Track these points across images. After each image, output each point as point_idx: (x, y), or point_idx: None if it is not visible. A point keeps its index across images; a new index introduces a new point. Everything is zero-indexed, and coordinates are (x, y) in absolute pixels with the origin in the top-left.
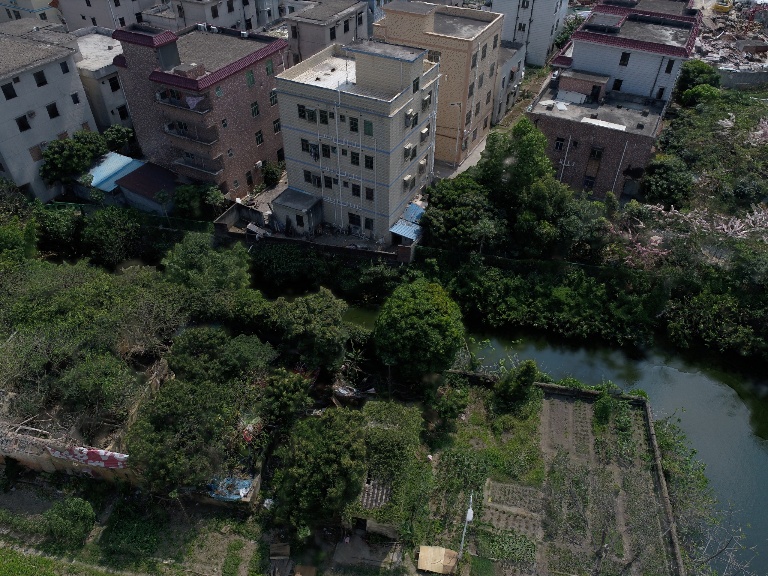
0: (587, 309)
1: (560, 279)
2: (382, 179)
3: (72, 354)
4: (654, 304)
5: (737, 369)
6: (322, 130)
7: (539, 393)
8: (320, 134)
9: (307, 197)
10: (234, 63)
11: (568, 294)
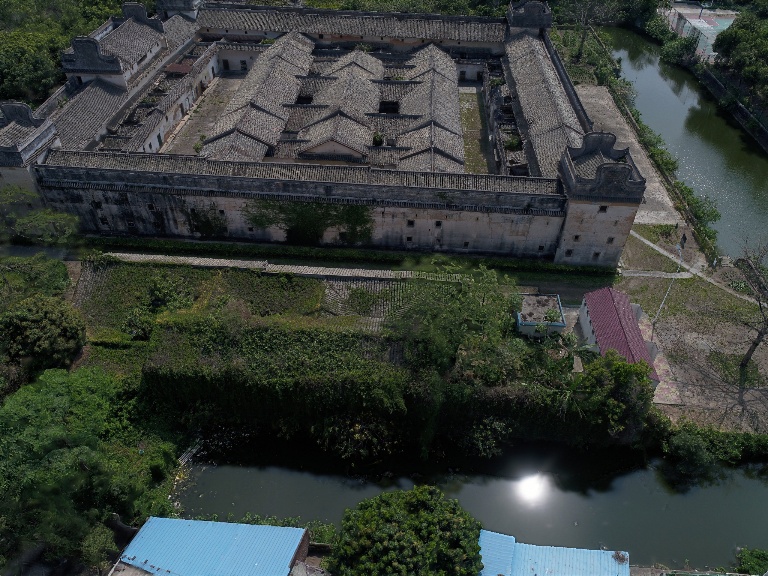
0: (567, 12)
1: (556, 5)
2: None
3: (407, 9)
4: (591, 7)
5: (621, 27)
6: None
7: (555, 27)
8: None
9: None
10: None
11: (560, 8)
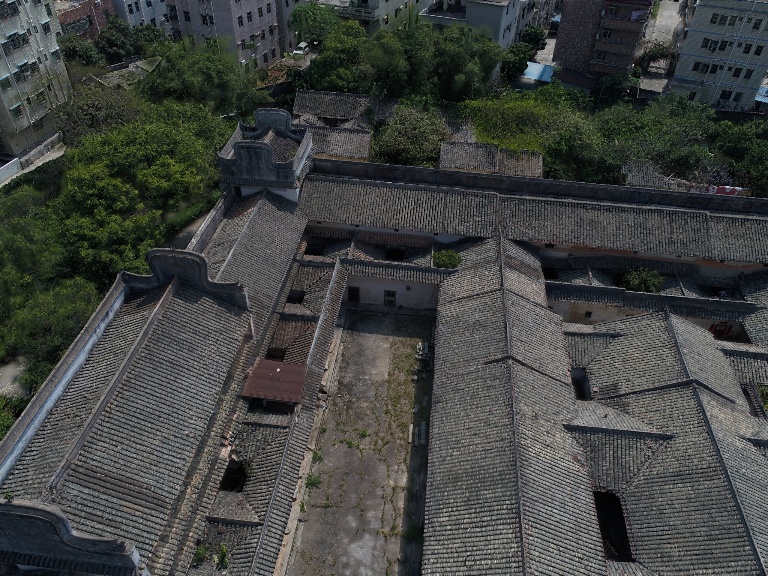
0: None
1: None
2: (765, 62)
3: (659, 149)
4: None
5: None
6: (727, 30)
7: None
8: (724, 33)
9: (692, 81)
10: None
11: None
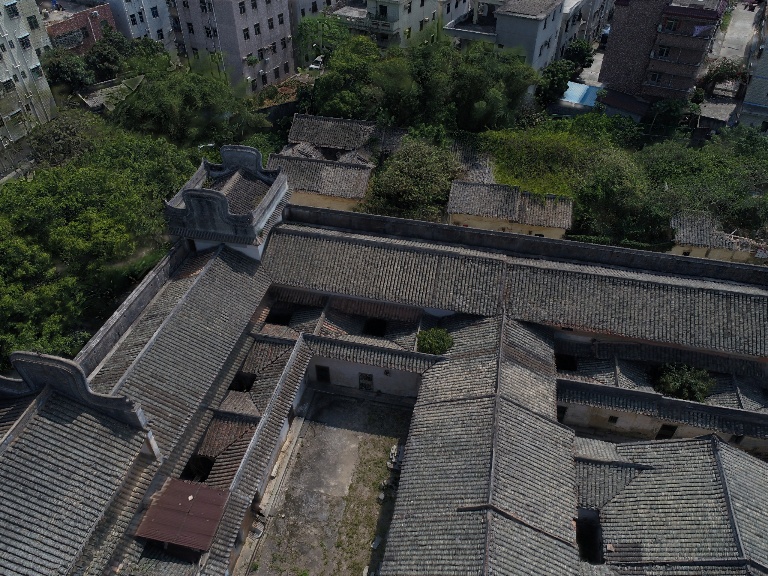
0: None
1: None
2: None
3: None
4: None
5: None
6: None
7: None
8: None
9: (766, 109)
10: (722, 1)
11: None
